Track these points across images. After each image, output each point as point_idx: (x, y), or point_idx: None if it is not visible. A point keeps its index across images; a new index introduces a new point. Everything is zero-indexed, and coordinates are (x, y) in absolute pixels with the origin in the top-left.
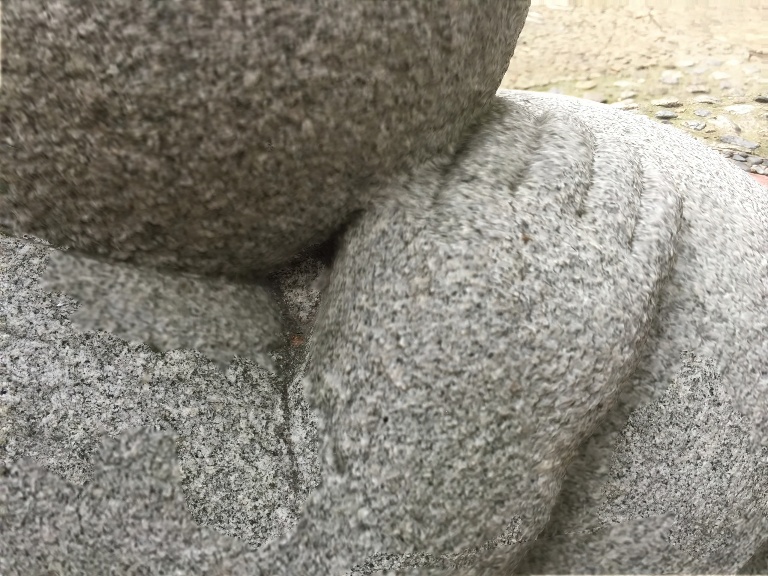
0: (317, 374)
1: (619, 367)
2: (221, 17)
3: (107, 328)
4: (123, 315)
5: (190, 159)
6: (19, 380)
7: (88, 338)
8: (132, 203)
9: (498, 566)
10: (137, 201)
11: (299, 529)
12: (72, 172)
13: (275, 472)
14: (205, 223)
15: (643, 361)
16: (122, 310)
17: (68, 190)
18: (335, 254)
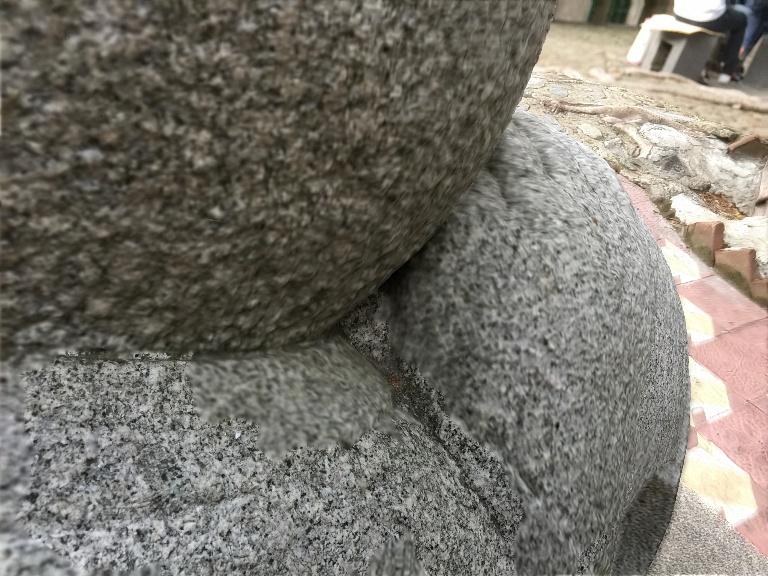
0: (465, 408)
1: None
2: (493, 19)
3: (299, 442)
4: (302, 418)
5: (405, 196)
6: (245, 561)
7: (290, 464)
8: (319, 267)
9: None
10: (326, 263)
11: (518, 571)
12: (284, 241)
13: (483, 526)
14: (364, 273)
15: None
16: (297, 413)
17: (255, 269)
18: (407, 277)
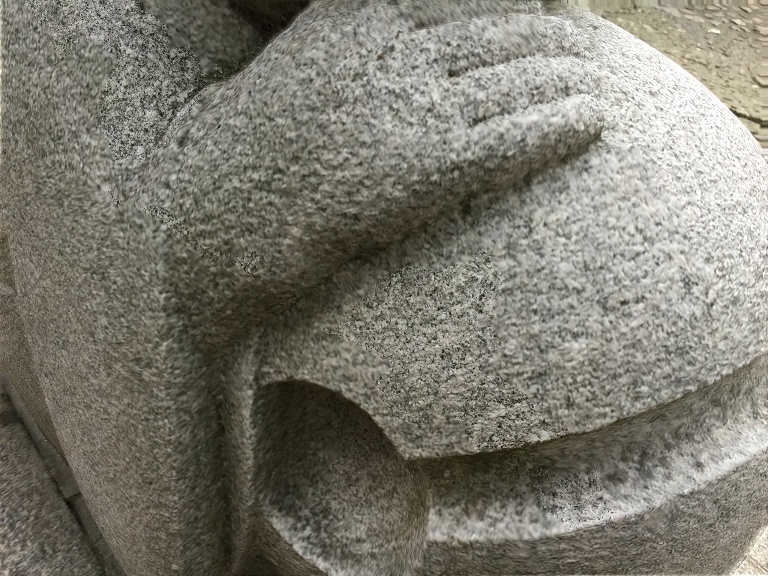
0: None
1: (386, 197)
2: None
3: None
4: None
5: None
6: None
7: None
8: None
9: (234, 283)
10: None
11: (142, 166)
12: None
13: (153, 124)
14: None
15: (444, 235)
16: None
17: None
18: None
